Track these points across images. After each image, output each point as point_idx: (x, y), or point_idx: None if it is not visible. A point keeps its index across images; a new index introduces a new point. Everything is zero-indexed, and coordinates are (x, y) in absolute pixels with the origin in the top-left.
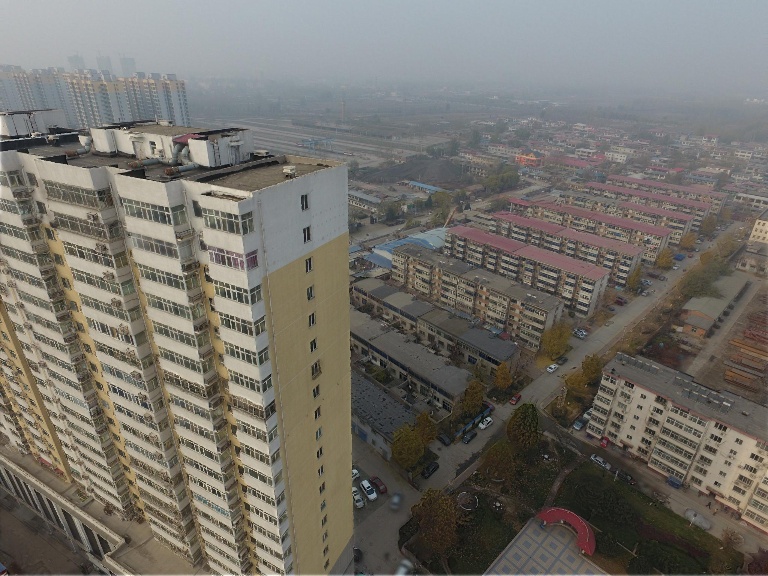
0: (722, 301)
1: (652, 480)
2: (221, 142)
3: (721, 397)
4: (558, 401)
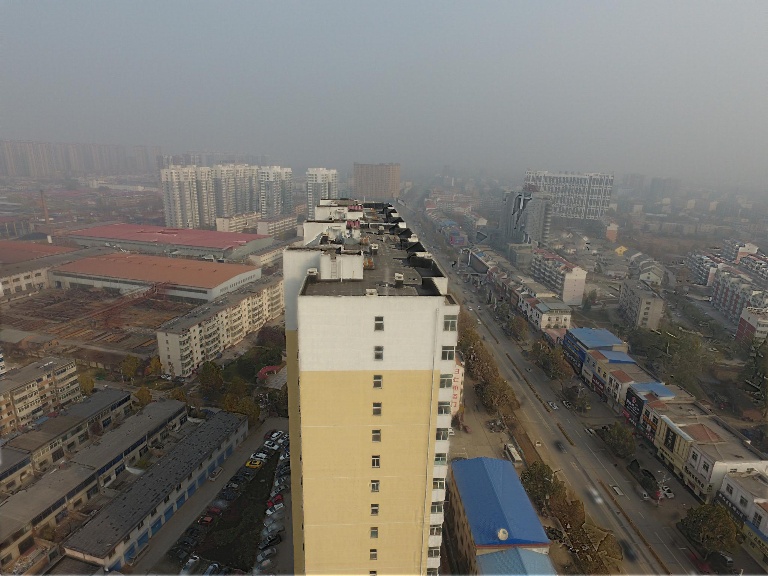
0: (6, 330)
1: (218, 362)
2: None
3: (200, 309)
4: (173, 375)
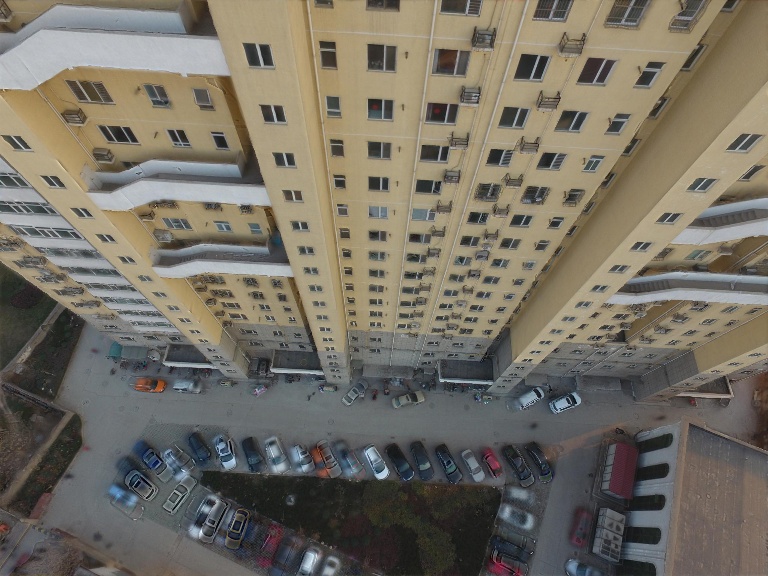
0: None
1: None
2: None
3: None
4: None
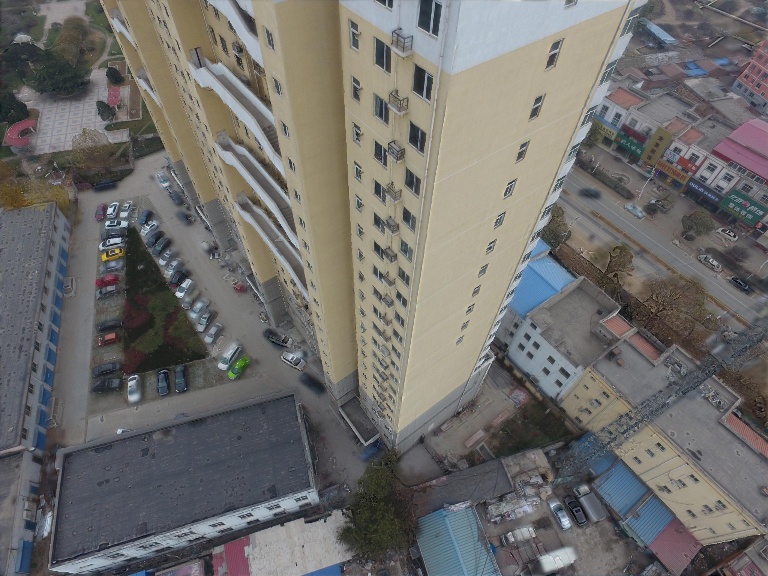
0: None
1: None
2: None
3: None
4: None
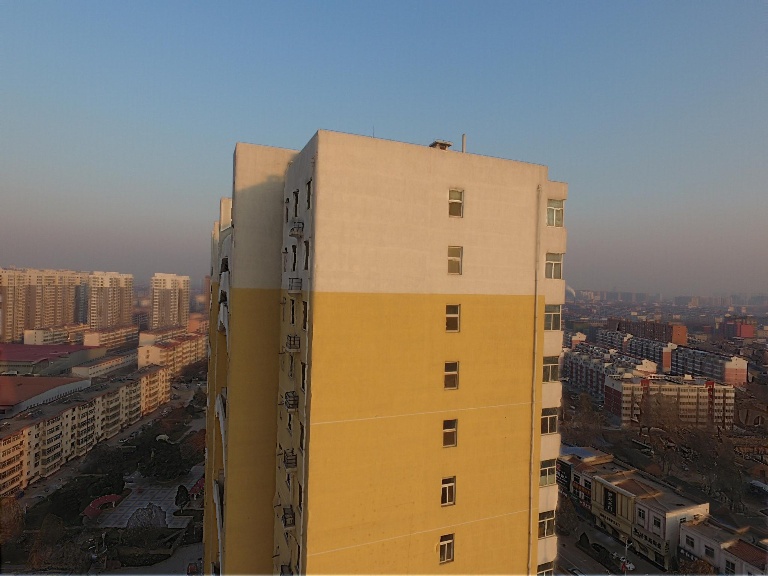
0: None
1: None
2: None
3: None
4: None
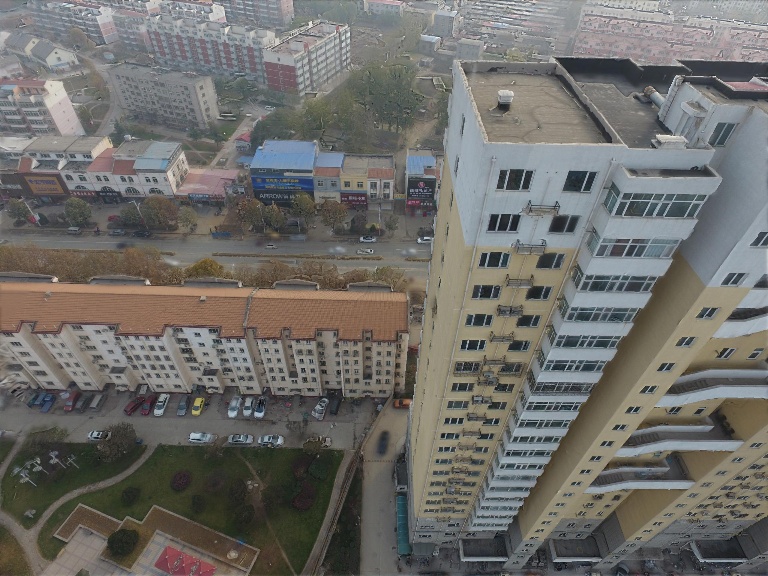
0: None
1: None
2: (688, 93)
3: None
4: None
